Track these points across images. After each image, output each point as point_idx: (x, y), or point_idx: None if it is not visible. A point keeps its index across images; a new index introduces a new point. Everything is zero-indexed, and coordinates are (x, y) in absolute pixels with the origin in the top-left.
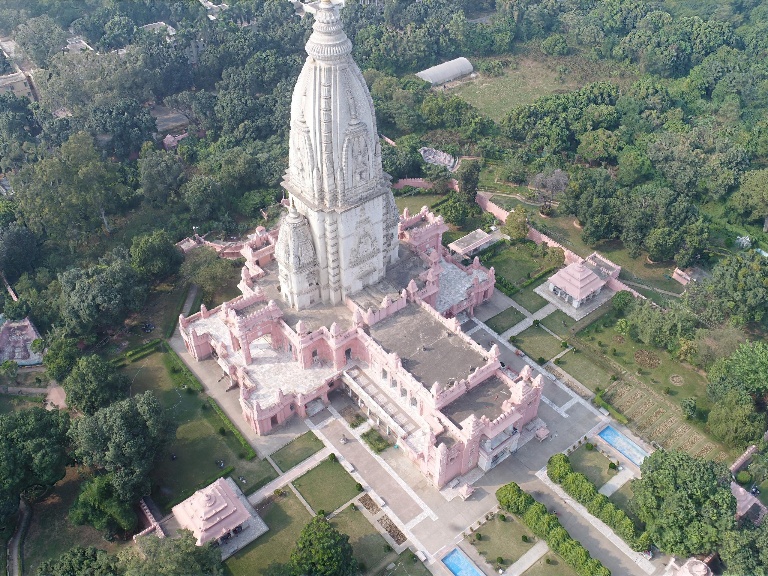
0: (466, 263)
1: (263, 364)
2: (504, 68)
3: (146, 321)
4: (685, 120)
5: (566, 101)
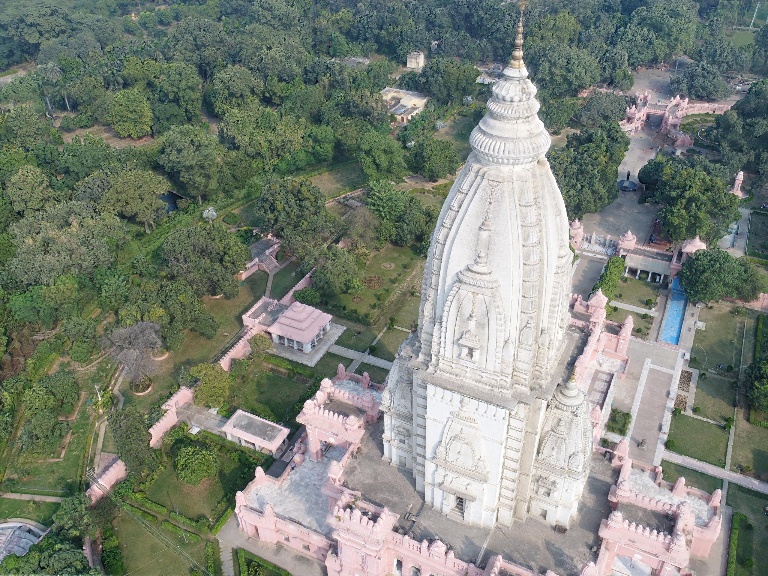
0: (293, 434)
1: None
2: None
3: None
4: None
5: None
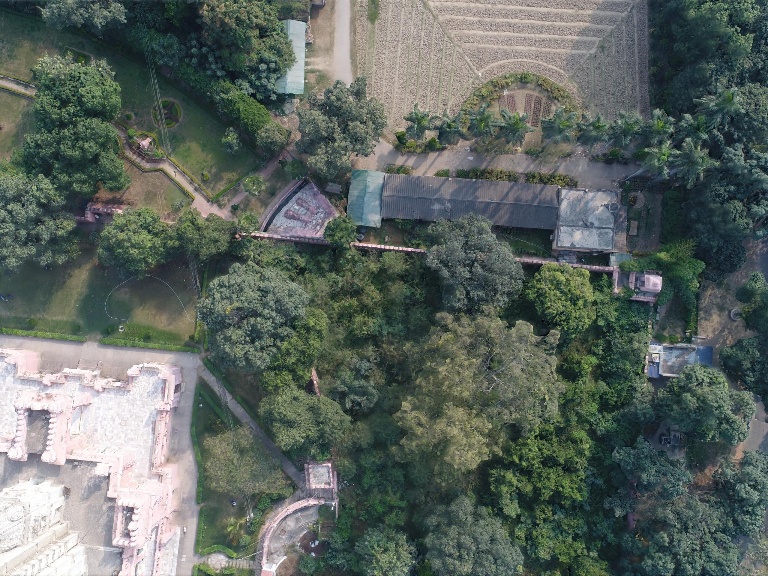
0: None
1: None
2: None
3: None
4: None
5: None
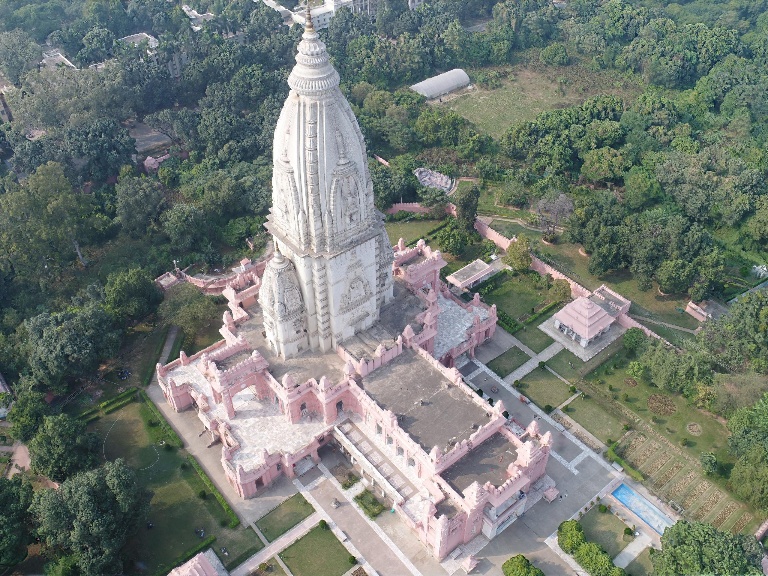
0: (465, 297)
1: (247, 418)
2: (502, 79)
3: (122, 366)
4: (693, 136)
5: (568, 117)
